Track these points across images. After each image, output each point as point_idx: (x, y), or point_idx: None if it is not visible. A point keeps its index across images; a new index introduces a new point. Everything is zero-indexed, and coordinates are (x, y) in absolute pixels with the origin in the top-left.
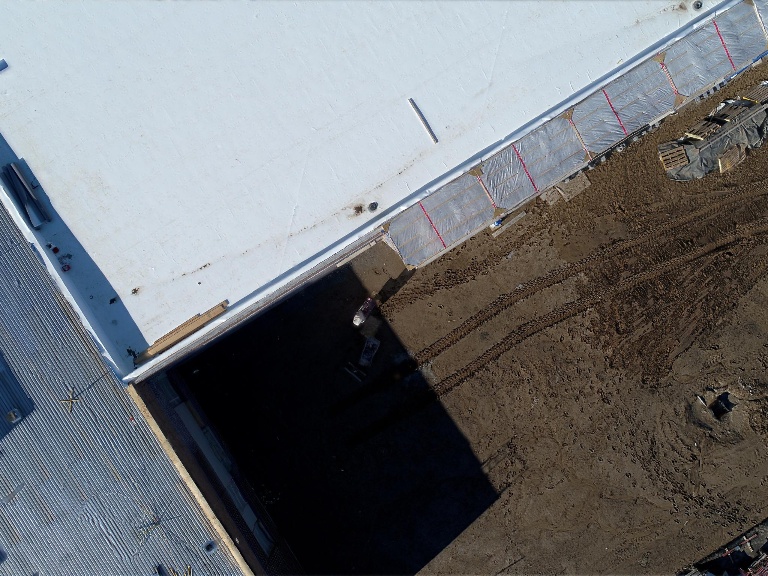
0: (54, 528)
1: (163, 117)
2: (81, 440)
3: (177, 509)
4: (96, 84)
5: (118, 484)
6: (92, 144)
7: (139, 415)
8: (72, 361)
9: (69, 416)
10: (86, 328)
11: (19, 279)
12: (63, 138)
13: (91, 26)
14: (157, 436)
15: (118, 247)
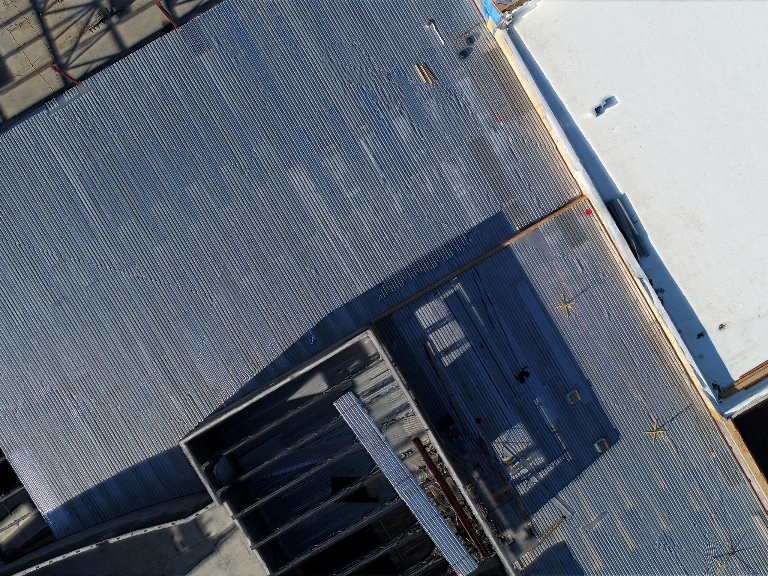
0: (633, 555)
1: (762, 156)
2: (663, 471)
3: (751, 540)
4: (701, 122)
5: (696, 514)
6: (692, 181)
7: (719, 448)
8: (657, 393)
9: (652, 447)
10: (689, 363)
11: (609, 311)
12: (665, 175)
13: (701, 65)
14: (752, 470)
15: (709, 283)
